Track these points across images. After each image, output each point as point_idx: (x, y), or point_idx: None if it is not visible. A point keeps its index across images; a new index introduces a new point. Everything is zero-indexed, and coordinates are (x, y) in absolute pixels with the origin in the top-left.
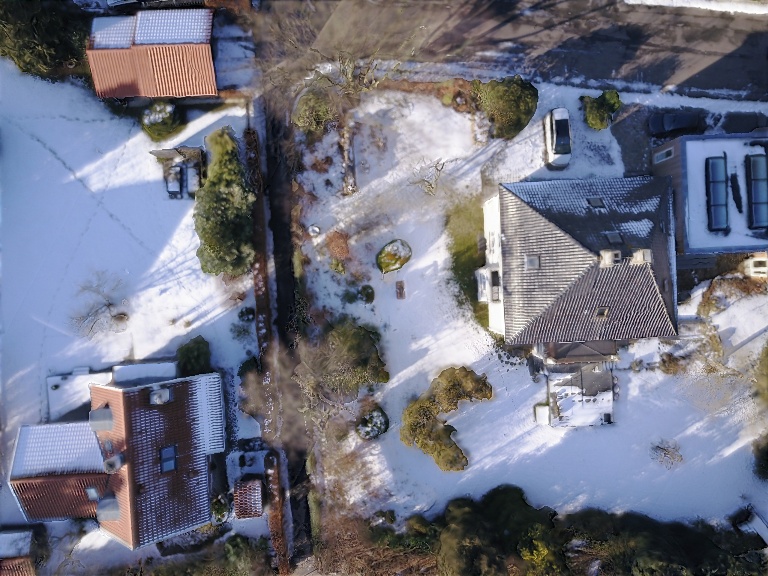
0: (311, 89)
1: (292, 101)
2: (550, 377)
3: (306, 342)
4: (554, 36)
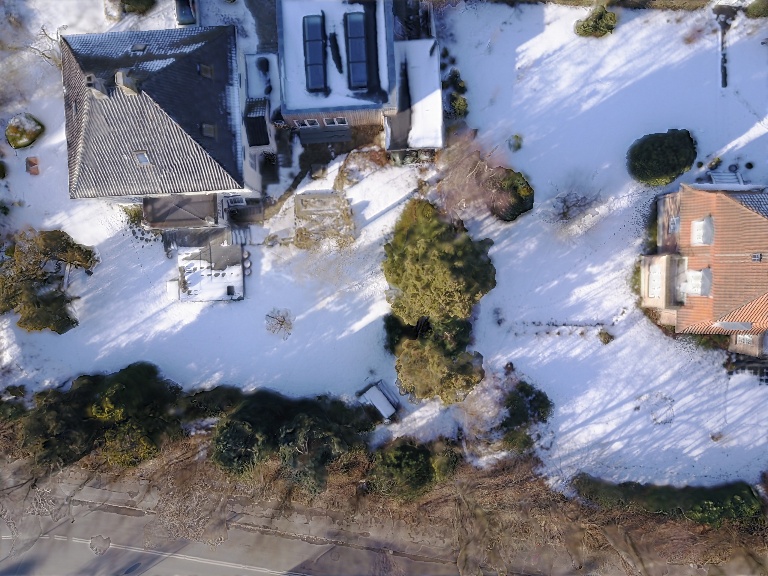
0: None
1: None
2: (178, 251)
3: None
4: None
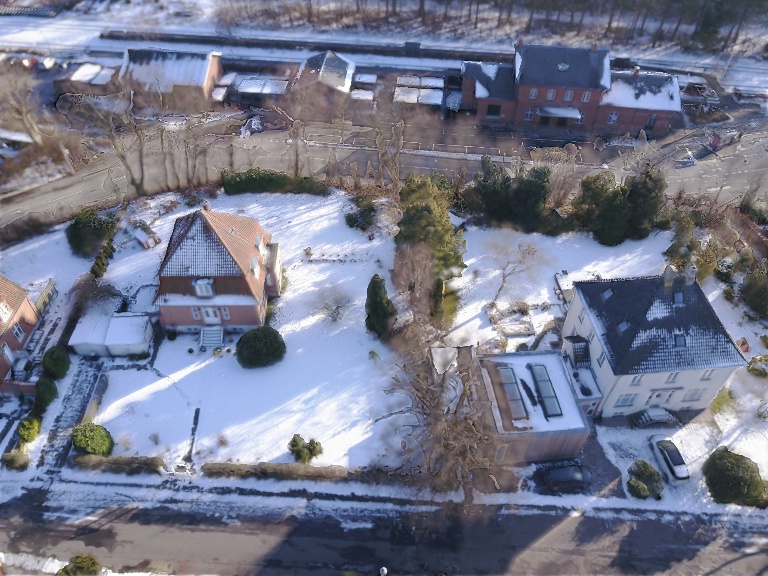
0: None
1: None
2: None
3: None
4: (708, 561)
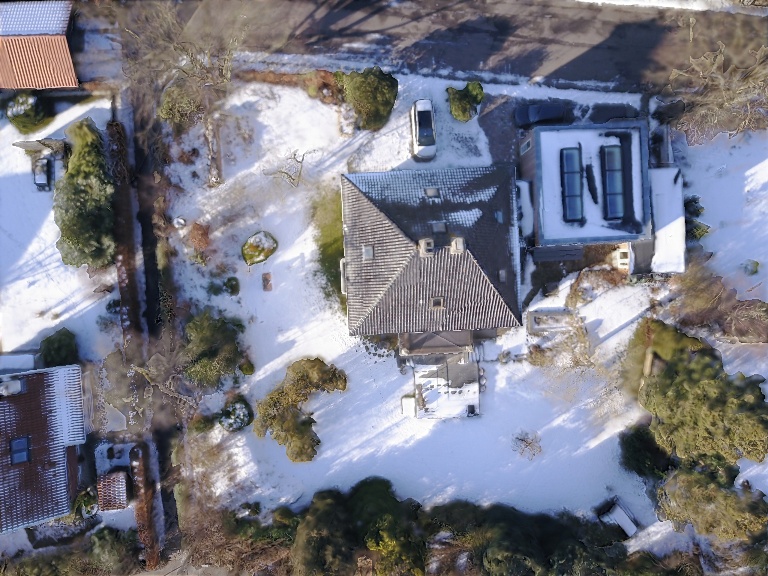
0: (176, 81)
1: (159, 93)
2: (416, 369)
3: (174, 334)
4: (421, 28)
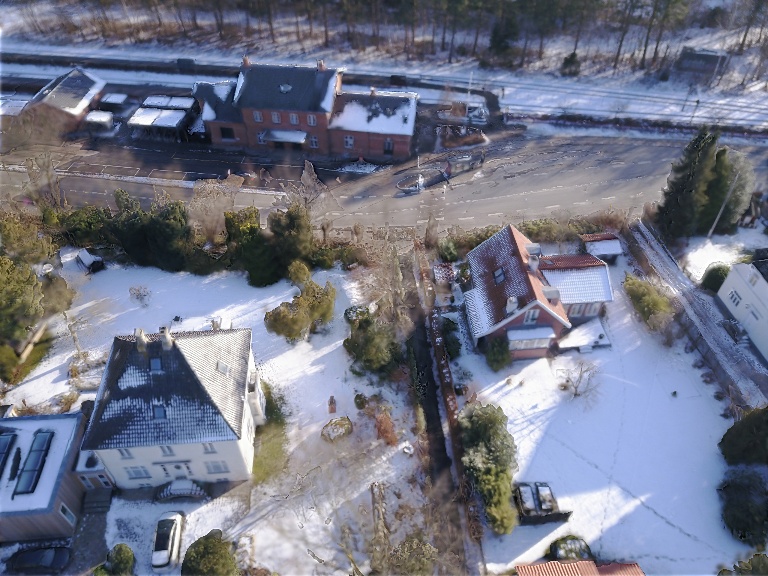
0: None
1: None
2: None
3: None
4: None
